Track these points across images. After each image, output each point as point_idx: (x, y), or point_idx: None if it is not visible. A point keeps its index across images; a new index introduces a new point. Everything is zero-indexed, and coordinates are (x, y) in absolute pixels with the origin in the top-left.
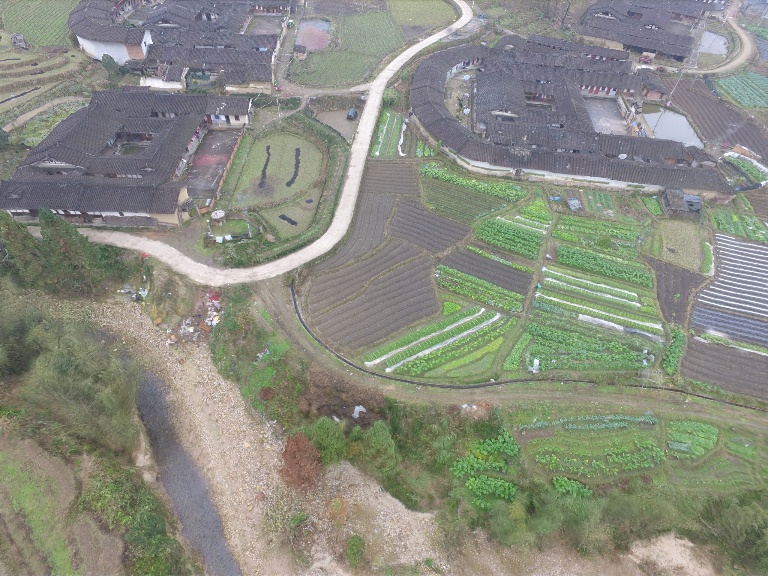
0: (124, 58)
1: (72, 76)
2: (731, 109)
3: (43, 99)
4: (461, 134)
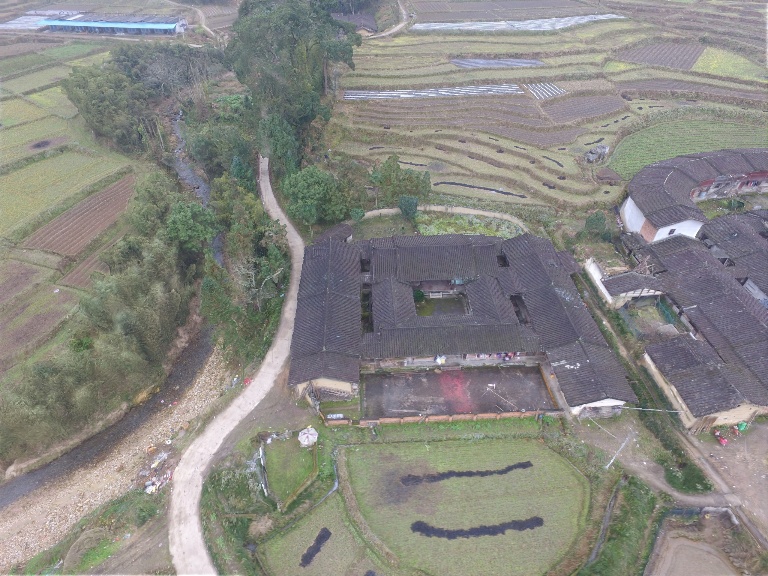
0: (636, 227)
1: (565, 207)
2: None
3: (505, 207)
4: None
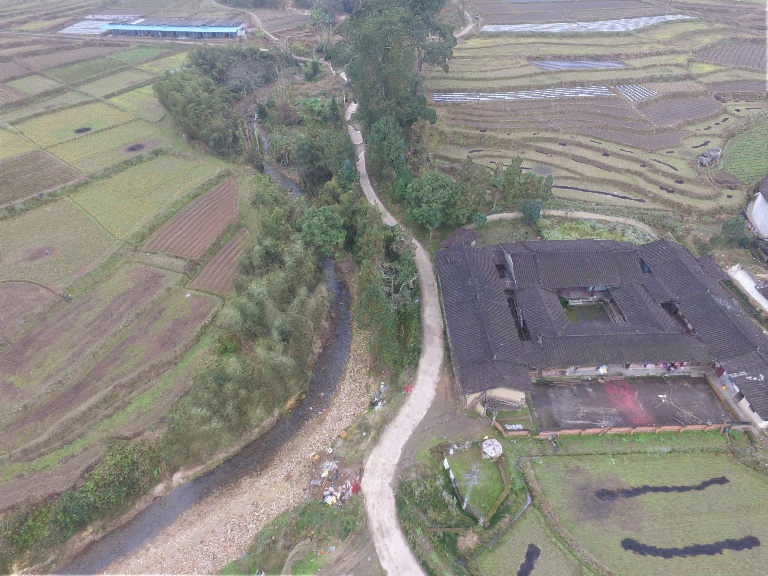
0: None
1: (689, 212)
2: None
3: (626, 212)
4: None
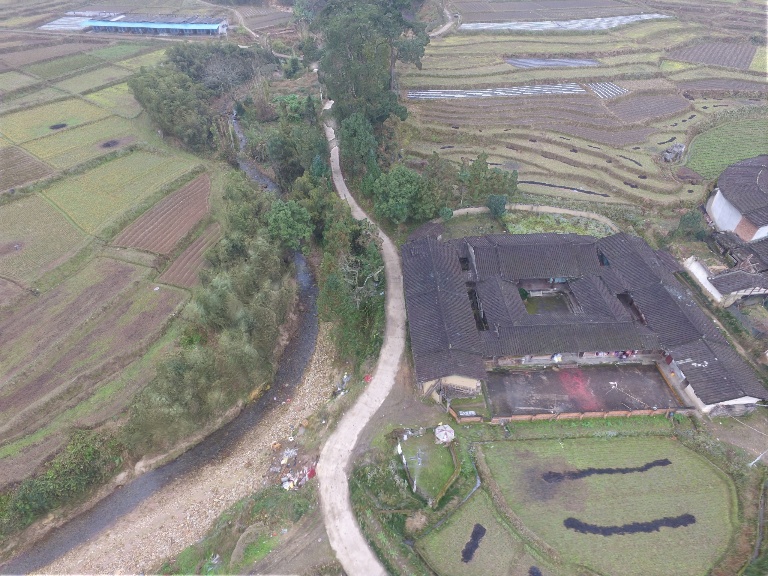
0: (729, 226)
1: (651, 206)
2: None
3: (590, 206)
4: None
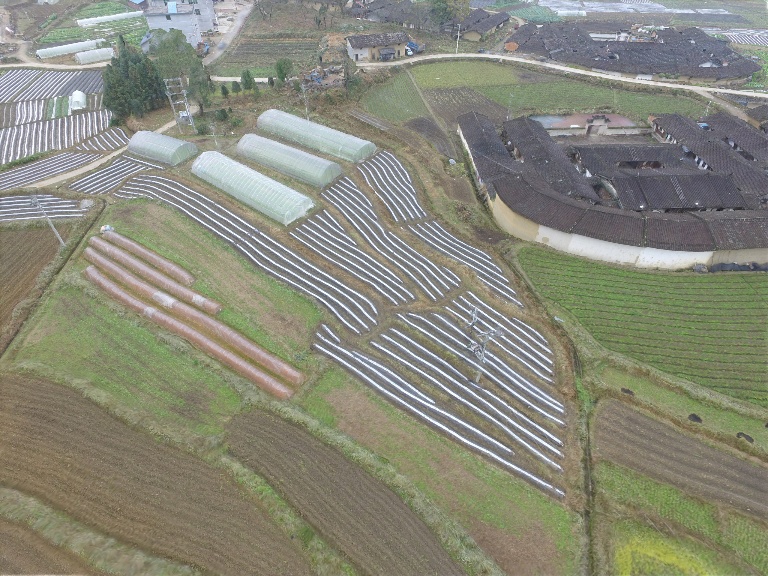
0: None
1: None
2: (573, 23)
3: None
4: (747, 64)
